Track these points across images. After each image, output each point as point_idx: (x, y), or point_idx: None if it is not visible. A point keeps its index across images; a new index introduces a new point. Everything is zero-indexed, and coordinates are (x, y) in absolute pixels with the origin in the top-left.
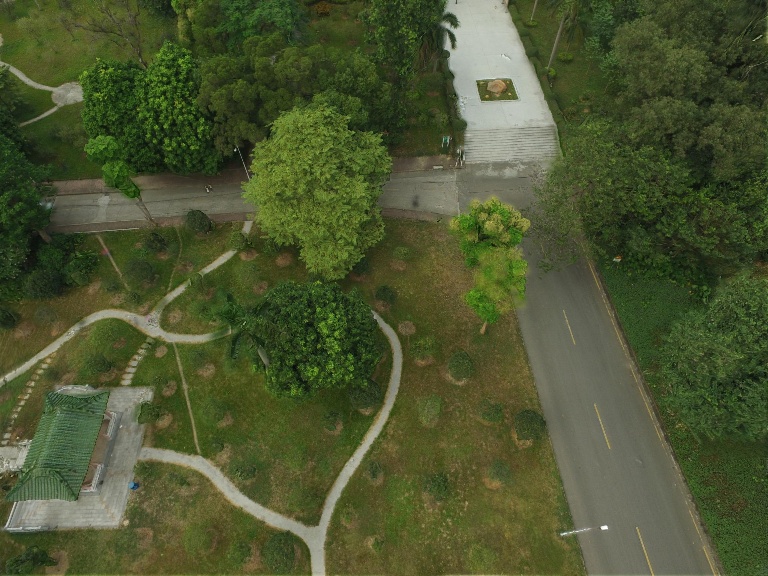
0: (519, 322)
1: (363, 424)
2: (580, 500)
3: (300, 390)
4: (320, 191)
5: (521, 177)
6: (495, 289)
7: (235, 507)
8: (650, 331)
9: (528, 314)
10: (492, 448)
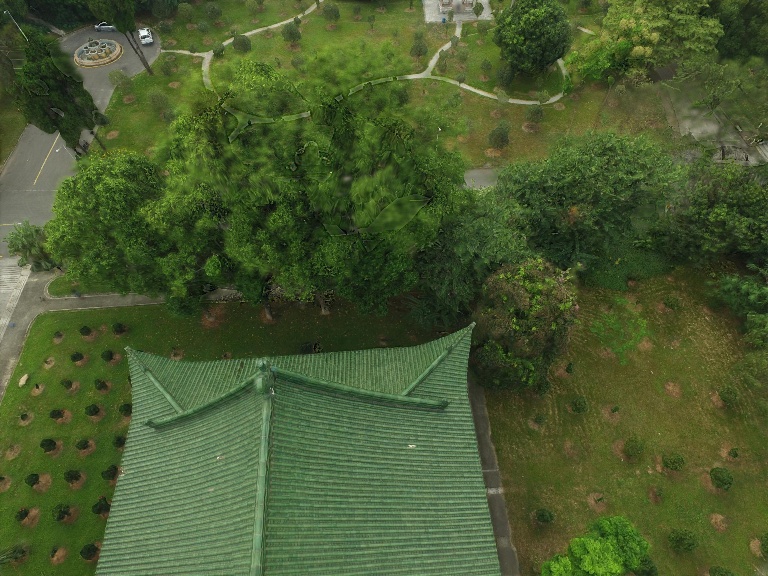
0: None
1: (487, 89)
2: None
3: (498, 27)
4: (640, 1)
5: None
6: None
7: (438, 50)
8: None
9: None
10: (482, 139)
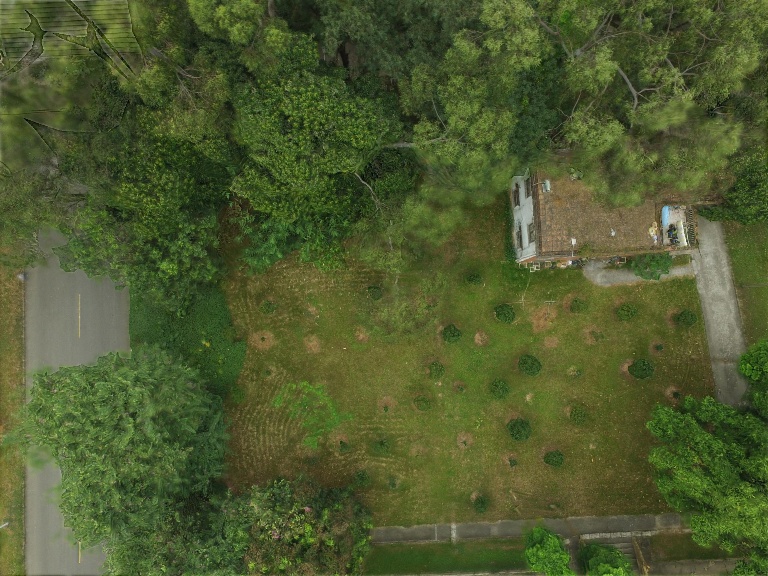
0: (26, 309)
1: None
2: (38, 493)
3: None
4: None
5: (32, 110)
6: (1, 268)
7: None
8: (135, 338)
9: (38, 299)
10: None
